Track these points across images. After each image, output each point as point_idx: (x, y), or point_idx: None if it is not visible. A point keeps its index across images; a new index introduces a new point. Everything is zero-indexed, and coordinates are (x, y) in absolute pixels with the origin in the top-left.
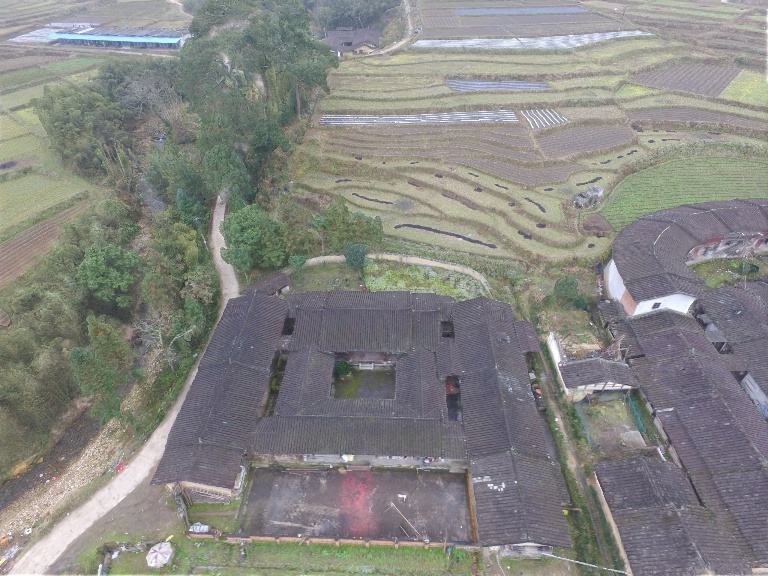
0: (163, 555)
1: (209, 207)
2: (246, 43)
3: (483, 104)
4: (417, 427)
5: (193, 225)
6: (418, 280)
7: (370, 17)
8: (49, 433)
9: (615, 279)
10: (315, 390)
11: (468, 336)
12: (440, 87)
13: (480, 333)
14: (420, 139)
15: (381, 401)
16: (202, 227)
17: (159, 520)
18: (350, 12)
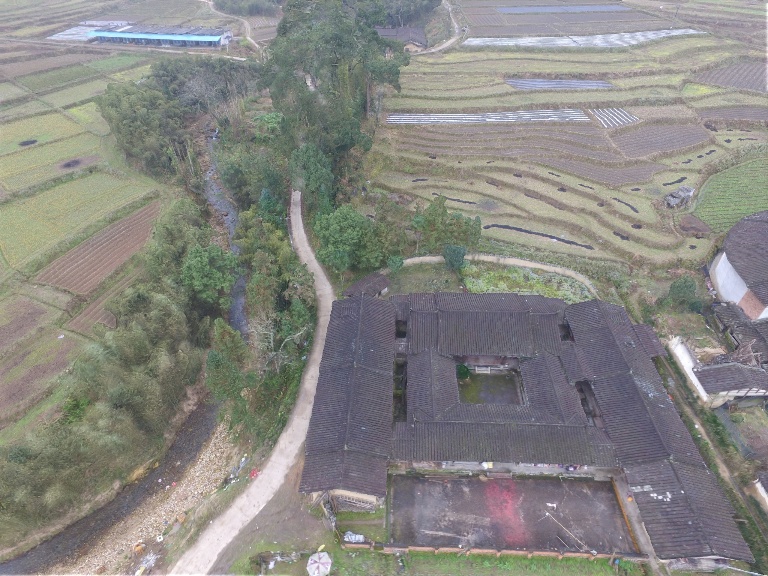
0: (324, 566)
1: (284, 207)
2: (330, 40)
3: (550, 103)
4: (562, 434)
5: (276, 225)
6: (519, 282)
7: (410, 15)
8: (162, 437)
9: (729, 281)
10: (445, 395)
11: (590, 340)
12: (501, 85)
13: (603, 337)
14: (493, 138)
15: (515, 406)
16: (281, 227)
17: (306, 529)
18: (389, 10)
